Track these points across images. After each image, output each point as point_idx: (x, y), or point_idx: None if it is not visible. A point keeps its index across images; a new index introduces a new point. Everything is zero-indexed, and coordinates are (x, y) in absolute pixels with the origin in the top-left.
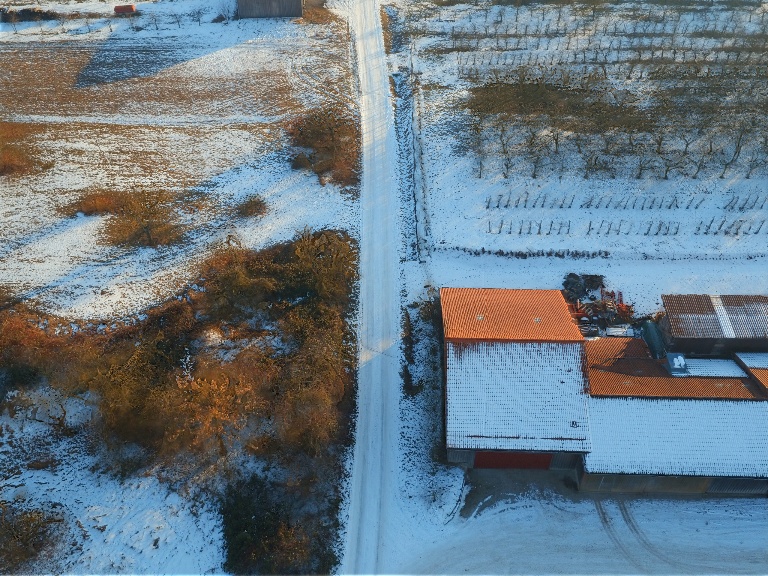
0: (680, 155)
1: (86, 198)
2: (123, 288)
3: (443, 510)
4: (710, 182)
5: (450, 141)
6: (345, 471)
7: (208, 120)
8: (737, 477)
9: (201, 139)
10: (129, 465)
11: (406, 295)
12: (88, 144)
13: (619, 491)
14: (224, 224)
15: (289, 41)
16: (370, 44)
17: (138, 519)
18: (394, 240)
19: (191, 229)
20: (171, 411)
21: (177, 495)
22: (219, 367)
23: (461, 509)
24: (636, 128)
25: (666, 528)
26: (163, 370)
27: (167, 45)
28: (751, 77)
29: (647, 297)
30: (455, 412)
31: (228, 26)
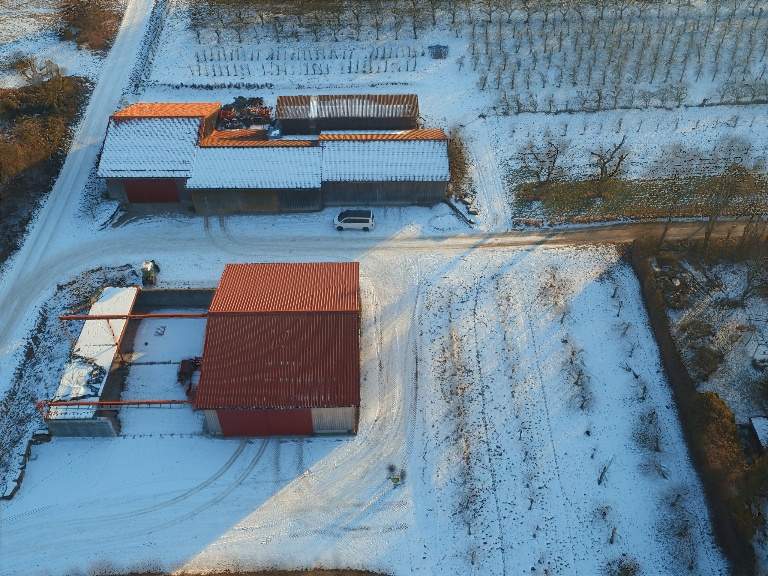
0: None
1: None
2: None
3: (98, 222)
4: (367, 42)
5: (187, 21)
6: (39, 205)
7: (6, 12)
8: (283, 188)
9: None
10: None
11: None
12: None
13: (222, 211)
14: None
15: None
16: None
17: None
18: (123, 82)
19: None
20: None
21: None
22: None
23: (113, 223)
24: (331, 11)
25: (245, 228)
26: None
27: None
28: None
29: None
30: (106, 158)
31: None
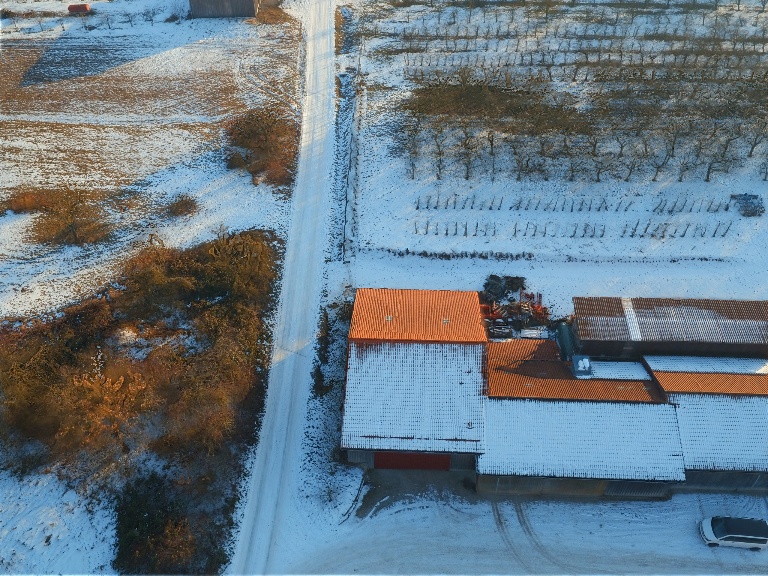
0: (615, 158)
1: (18, 196)
2: (44, 286)
3: (338, 510)
4: (642, 185)
5: (387, 142)
6: (245, 470)
7: (150, 119)
8: (628, 480)
9: (140, 138)
10: (30, 462)
11: (326, 295)
12: (26, 142)
13: (517, 493)
14: (153, 223)
15: (240, 41)
16: (321, 45)
17: (33, 516)
18: (321, 240)
19: (119, 228)
20: (62, 408)
21: (75, 492)
22: (129, 365)
23: (358, 509)
24: (574, 130)
25: (560, 530)
26: (71, 368)
27: (118, 44)
28: (696, 80)
29: (566, 299)
30: (352, 412)
31: (180, 26)
